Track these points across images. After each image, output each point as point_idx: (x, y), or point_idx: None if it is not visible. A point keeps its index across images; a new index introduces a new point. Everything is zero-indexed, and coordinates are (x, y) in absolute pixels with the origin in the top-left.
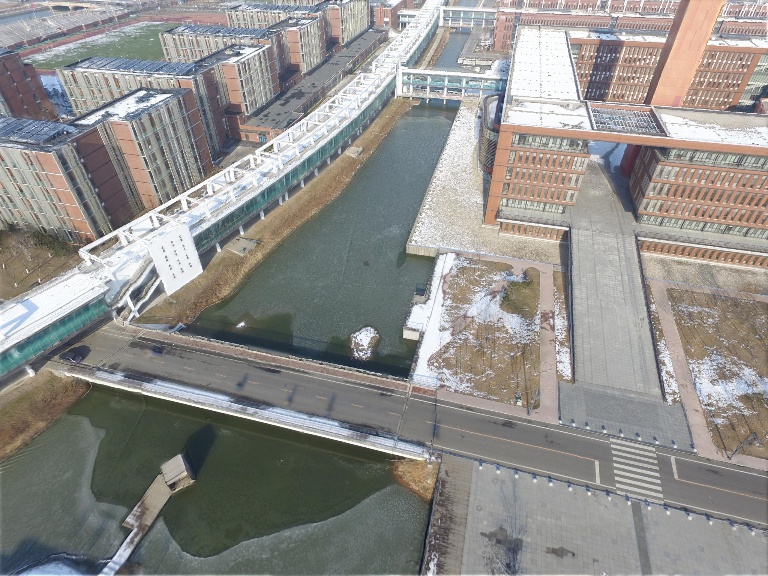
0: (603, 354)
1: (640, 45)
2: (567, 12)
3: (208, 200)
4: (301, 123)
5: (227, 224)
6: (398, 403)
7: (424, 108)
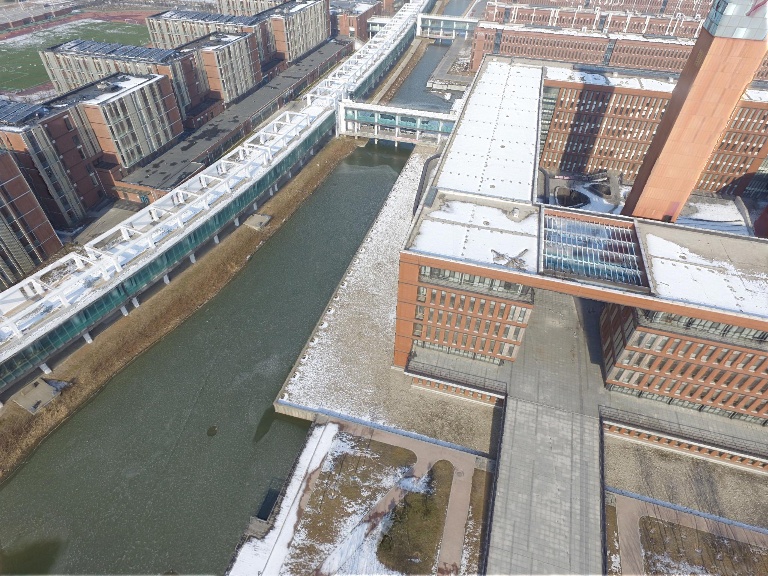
0: None
1: (634, 93)
2: (558, 30)
3: None
4: (173, 193)
5: (3, 374)
6: None
7: (372, 150)
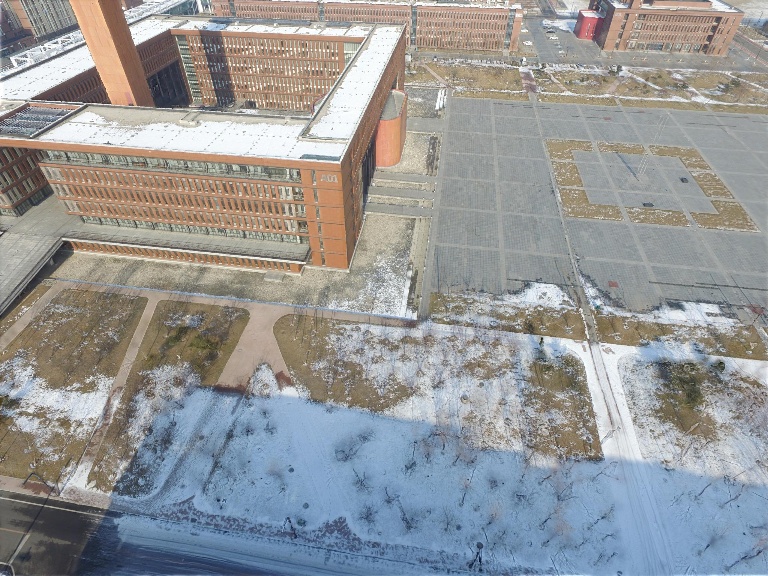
0: None
1: (236, 35)
2: None
3: None
4: None
5: None
6: None
7: None
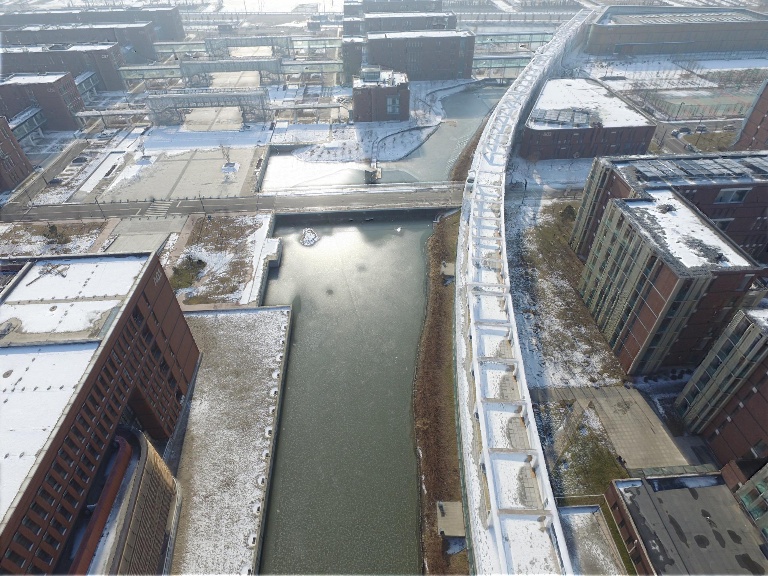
0: (142, 246)
1: None
2: None
3: (472, 219)
4: None
5: None
6: (278, 206)
7: None
